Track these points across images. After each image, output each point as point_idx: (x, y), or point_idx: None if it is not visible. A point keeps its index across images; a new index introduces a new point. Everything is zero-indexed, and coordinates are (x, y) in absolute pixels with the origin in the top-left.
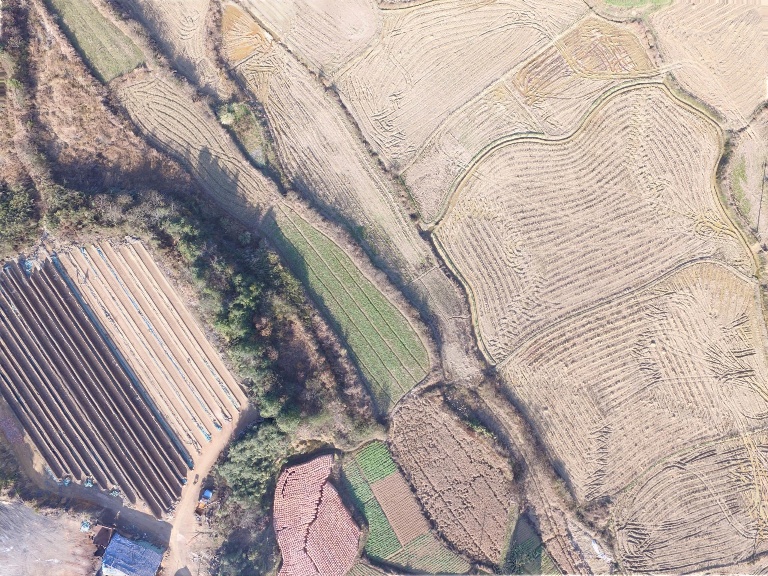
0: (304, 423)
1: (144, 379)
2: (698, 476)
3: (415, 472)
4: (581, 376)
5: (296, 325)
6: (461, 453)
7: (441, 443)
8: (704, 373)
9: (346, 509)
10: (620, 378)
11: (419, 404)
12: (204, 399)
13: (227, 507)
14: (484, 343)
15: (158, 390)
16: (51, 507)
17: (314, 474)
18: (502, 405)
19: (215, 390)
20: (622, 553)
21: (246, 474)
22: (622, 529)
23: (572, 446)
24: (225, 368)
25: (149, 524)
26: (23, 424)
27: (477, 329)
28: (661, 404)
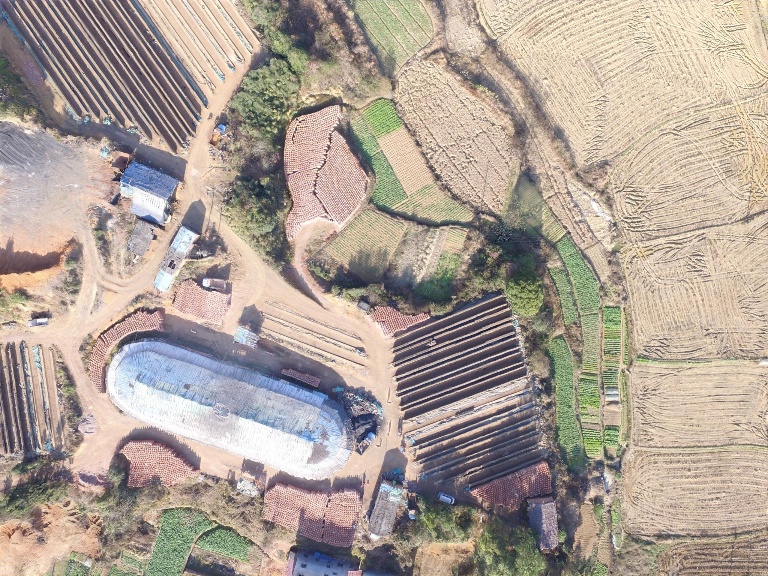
0: (314, 64)
1: (160, 25)
2: (693, 142)
3: (420, 129)
4: (579, 49)
5: None
6: (464, 111)
7: (445, 101)
8: (697, 46)
9: (354, 155)
10: (616, 51)
11: (423, 66)
12: (218, 42)
13: (240, 139)
14: (485, 19)
15: (174, 35)
16: None
17: (323, 122)
18: (503, 72)
19: (228, 34)
20: (620, 214)
21: (258, 104)
22: (620, 191)
23: (571, 114)
24: (238, 14)
25: (165, 160)
26: (44, 66)
27: (479, 5)
28: (656, 75)
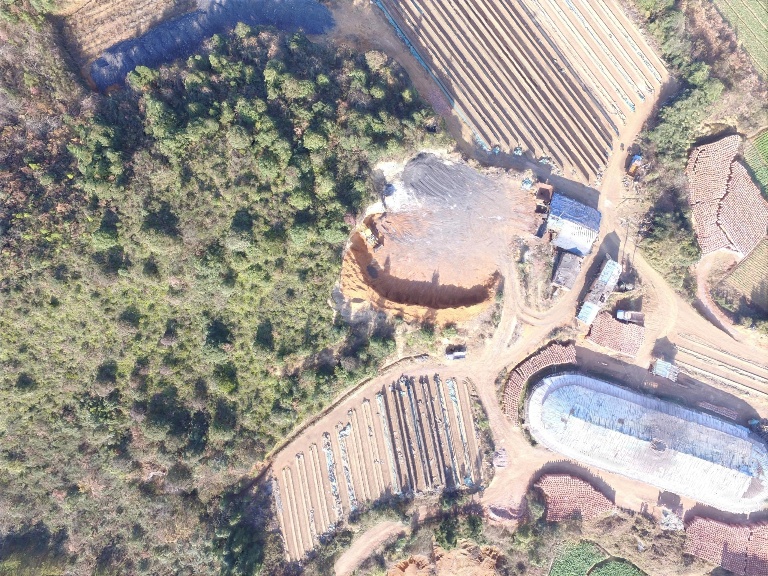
0: (724, 94)
1: (567, 54)
2: None
3: None
4: None
5: (698, 13)
6: None
7: None
8: None
9: (755, 185)
10: None
11: None
12: (626, 72)
13: (658, 170)
14: None
15: (581, 64)
16: (493, 166)
17: (724, 152)
18: None
19: (637, 64)
20: None
21: None
22: None
23: None
24: (646, 43)
25: (577, 191)
26: (452, 96)
27: None
28: None
